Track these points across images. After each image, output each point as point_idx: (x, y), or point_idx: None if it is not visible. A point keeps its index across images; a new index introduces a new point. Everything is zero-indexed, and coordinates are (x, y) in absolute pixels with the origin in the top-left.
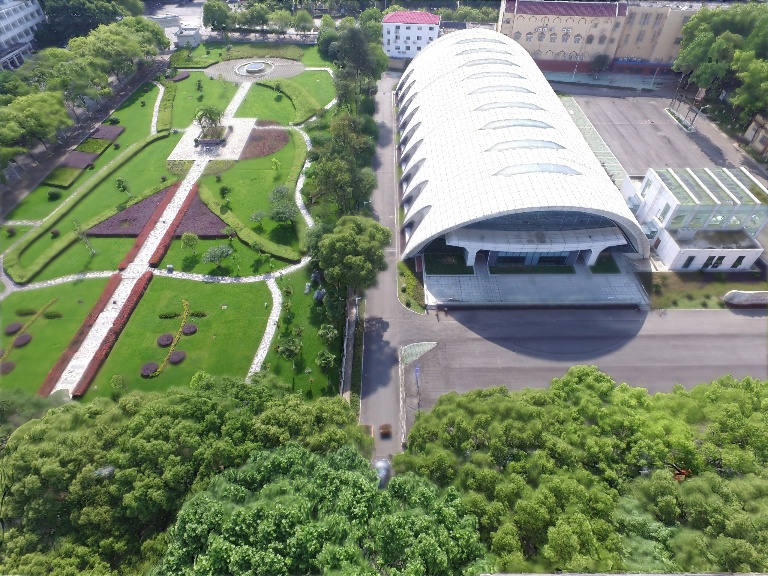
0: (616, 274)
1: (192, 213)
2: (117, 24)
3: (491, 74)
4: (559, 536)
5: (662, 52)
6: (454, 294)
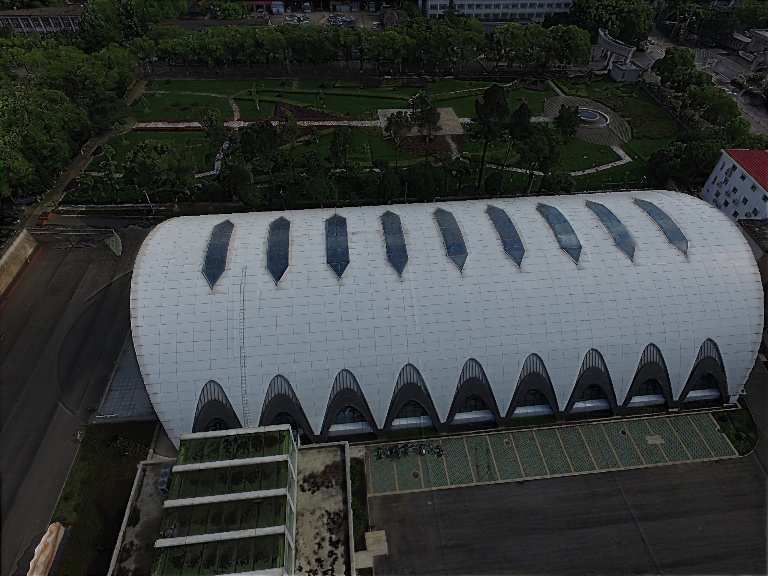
0: None
1: None
2: None
3: None
4: None
5: None
6: None
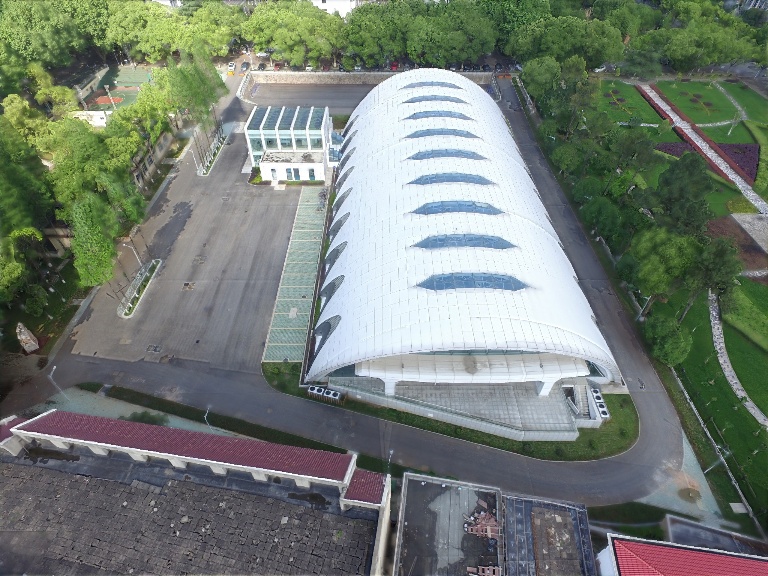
0: None
1: None
2: None
3: None
4: None
5: None
6: None
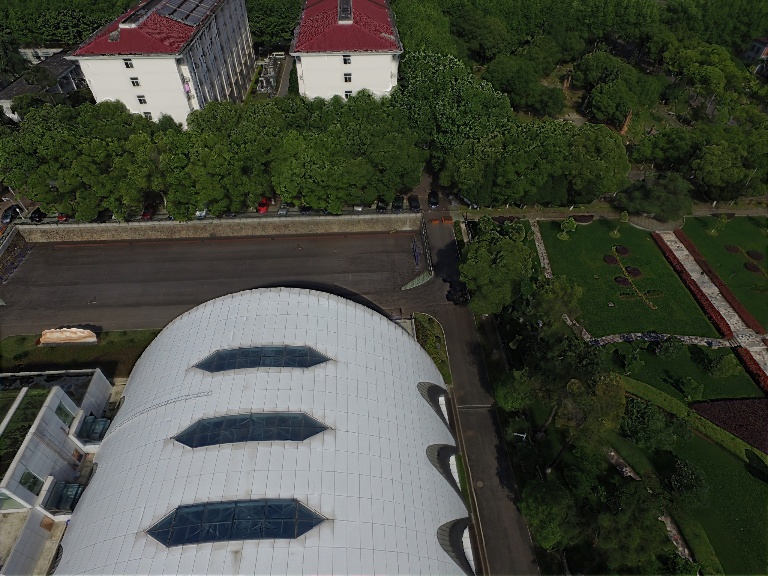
0: None
1: None
2: None
3: None
4: (369, 91)
5: None
6: None
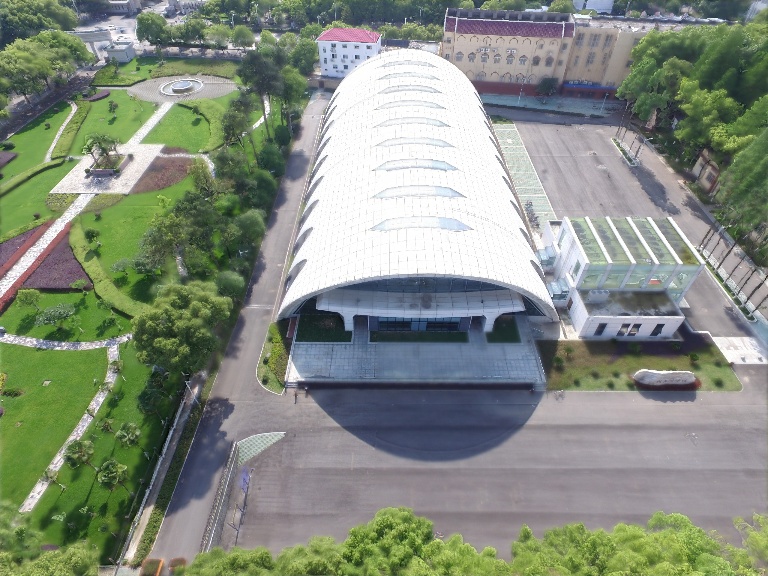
0: (515, 344)
1: (52, 260)
2: (31, 39)
3: (406, 103)
4: None
5: (614, 75)
6: (321, 368)
